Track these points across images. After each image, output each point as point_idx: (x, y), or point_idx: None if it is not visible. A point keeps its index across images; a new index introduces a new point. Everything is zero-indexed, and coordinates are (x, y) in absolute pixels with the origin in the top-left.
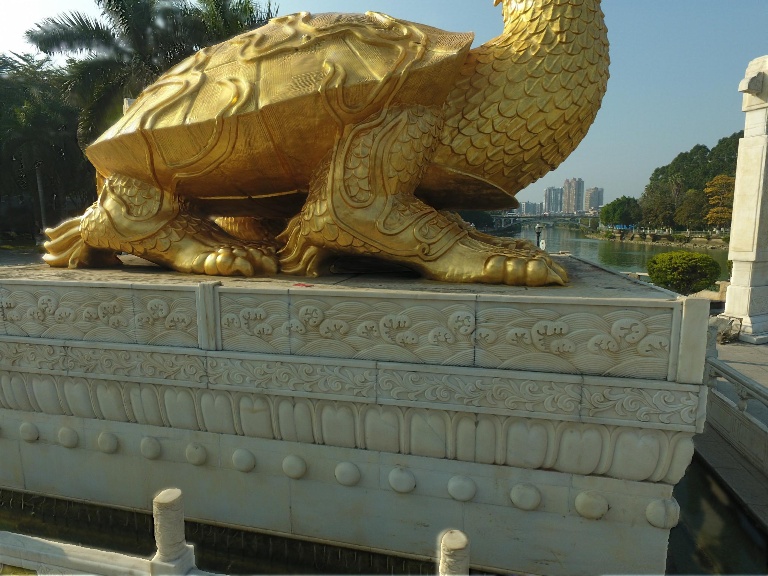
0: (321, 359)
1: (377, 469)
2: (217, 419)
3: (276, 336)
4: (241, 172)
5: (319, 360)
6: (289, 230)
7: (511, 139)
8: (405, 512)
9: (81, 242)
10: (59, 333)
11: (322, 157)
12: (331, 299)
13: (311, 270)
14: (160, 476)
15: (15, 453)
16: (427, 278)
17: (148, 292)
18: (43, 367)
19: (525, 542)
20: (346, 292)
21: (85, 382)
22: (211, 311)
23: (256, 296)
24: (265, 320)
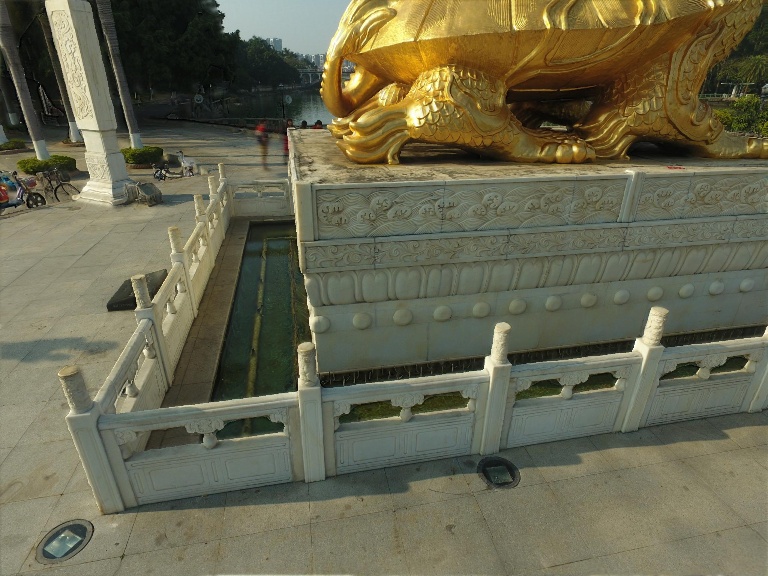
0: (703, 219)
1: (704, 284)
2: (615, 272)
3: (675, 206)
4: (597, 71)
5: (703, 219)
6: (604, 121)
7: (723, 44)
8: (711, 306)
9: (401, 136)
10: (499, 224)
11: (652, 59)
12: (718, 177)
13: (625, 155)
14: (555, 322)
15: (423, 334)
16: (701, 156)
17: (588, 182)
18: (482, 255)
19: (766, 307)
20: (731, 171)
21: (516, 262)
22: (638, 193)
23: (670, 179)
24: (671, 196)
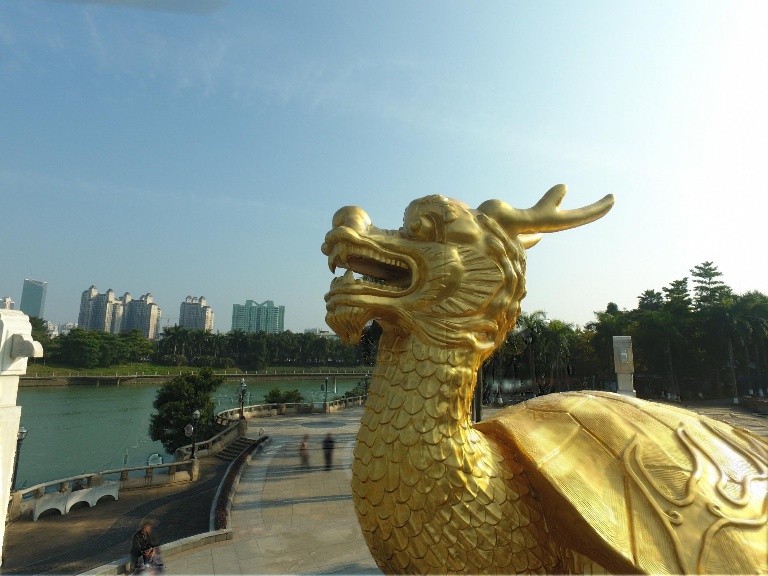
0: None
1: None
2: None
3: None
4: None
5: None
6: None
7: None
8: None
9: None
10: None
11: None
12: None
13: None
14: None
15: None
16: None
17: None
18: None
19: None
20: None
21: None
22: None
23: None
24: None
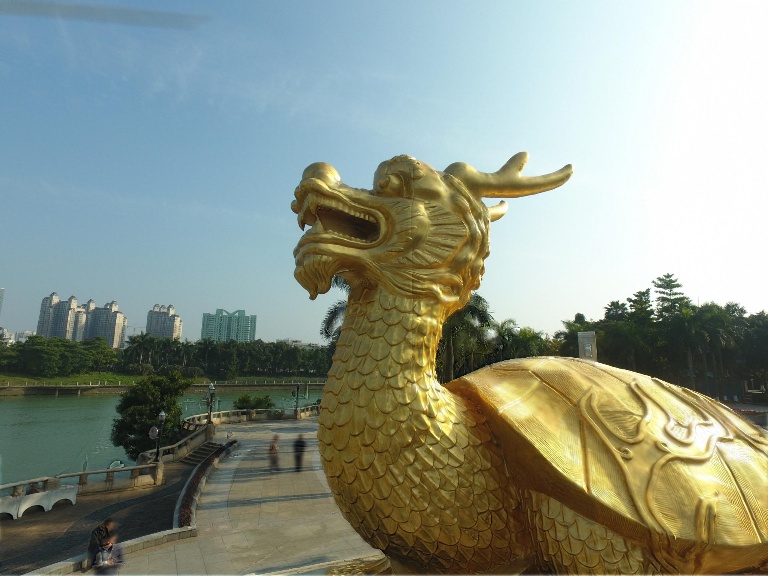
0: None
1: None
2: None
3: None
4: None
5: None
6: None
7: None
8: None
9: None
10: None
11: None
12: None
13: None
14: None
15: None
16: None
17: None
18: None
19: None
20: None
21: None
22: None
23: None
24: None
